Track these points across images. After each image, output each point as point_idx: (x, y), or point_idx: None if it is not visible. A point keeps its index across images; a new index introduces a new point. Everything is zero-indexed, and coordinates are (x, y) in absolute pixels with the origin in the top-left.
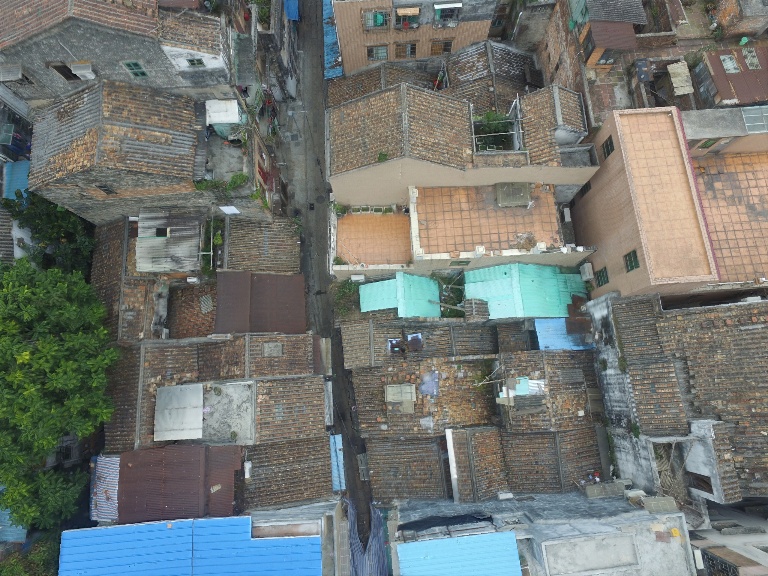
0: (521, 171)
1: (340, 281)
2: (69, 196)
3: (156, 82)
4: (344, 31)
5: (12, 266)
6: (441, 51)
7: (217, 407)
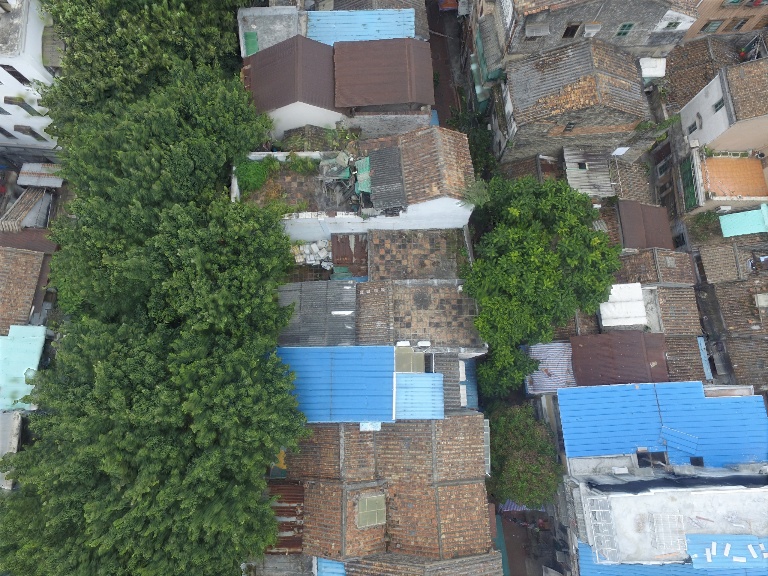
0: None
1: (693, 214)
2: (533, 132)
3: (624, 41)
4: (703, 7)
5: None
6: (763, 26)
7: None
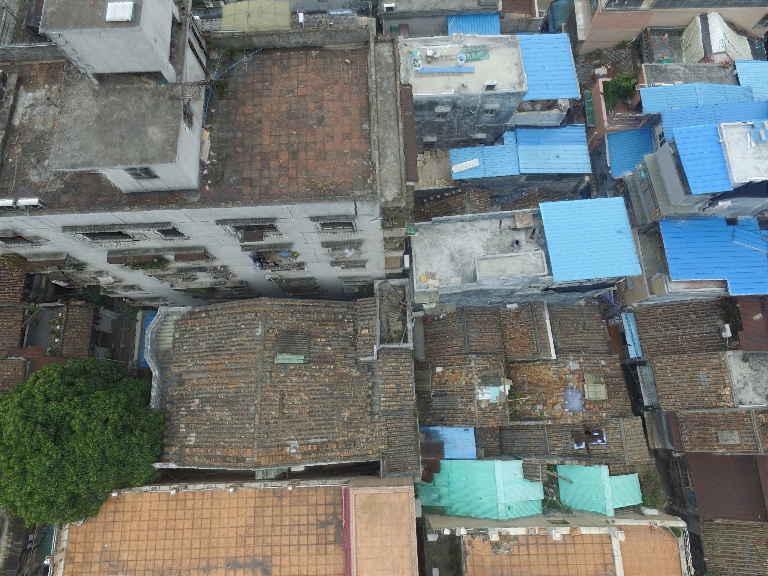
0: None
1: None
2: None
3: None
4: None
5: None
6: None
7: (766, 384)
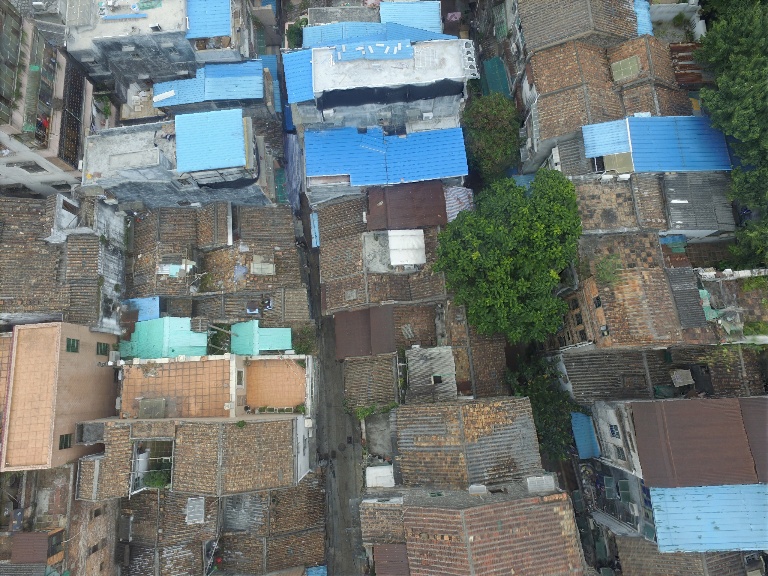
0: None
1: None
2: None
3: None
4: None
5: (563, 356)
6: None
7: None
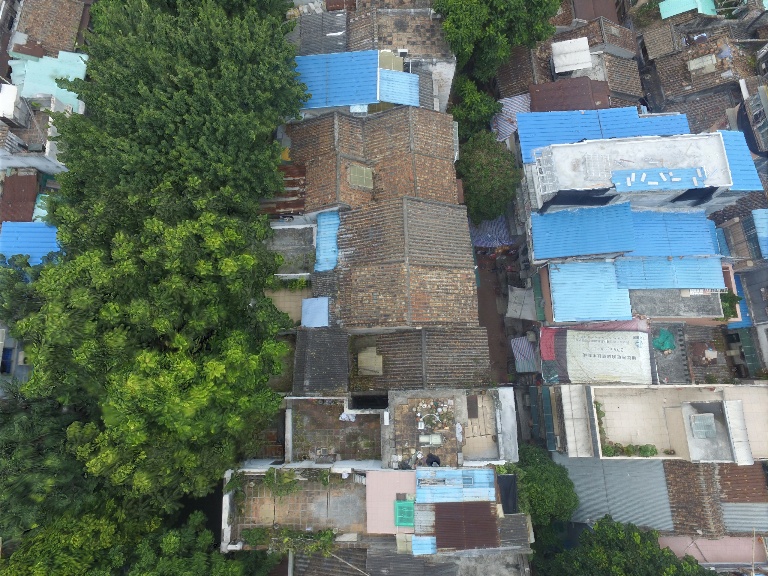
0: None
1: (638, 6)
2: None
3: None
4: None
5: None
6: None
7: None
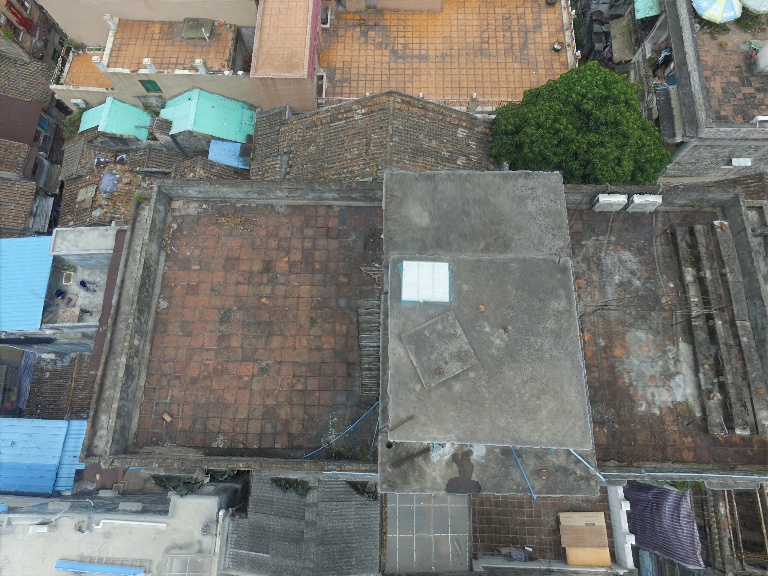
0: (192, 1)
1: (75, 113)
2: None
3: None
4: None
5: None
6: None
7: None
